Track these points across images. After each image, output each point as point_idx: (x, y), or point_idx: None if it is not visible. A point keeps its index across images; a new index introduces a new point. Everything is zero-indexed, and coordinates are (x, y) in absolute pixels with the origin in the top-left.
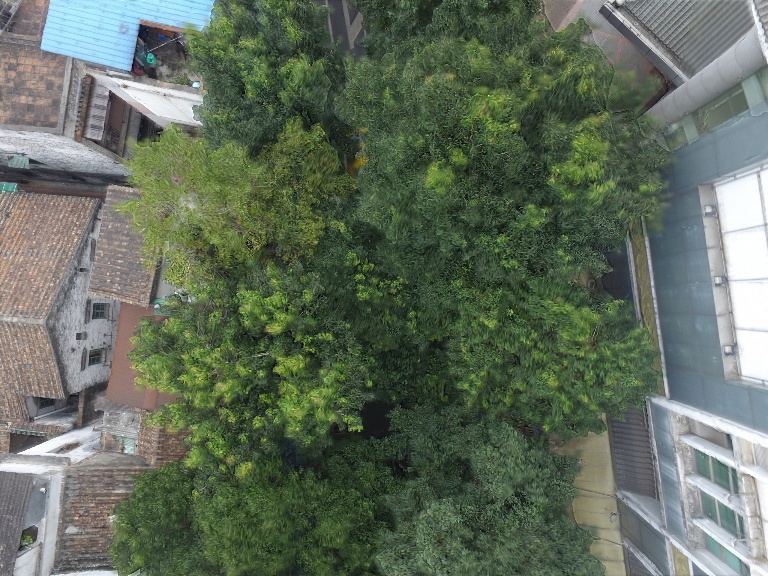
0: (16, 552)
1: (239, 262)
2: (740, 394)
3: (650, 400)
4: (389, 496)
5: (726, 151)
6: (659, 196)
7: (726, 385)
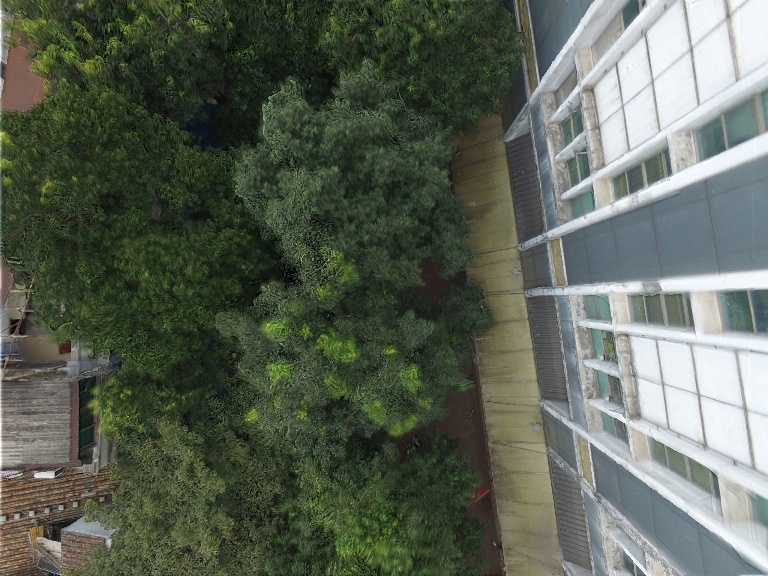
0: None
1: None
2: (575, 1)
3: (528, 105)
4: None
5: None
6: None
7: (567, 6)
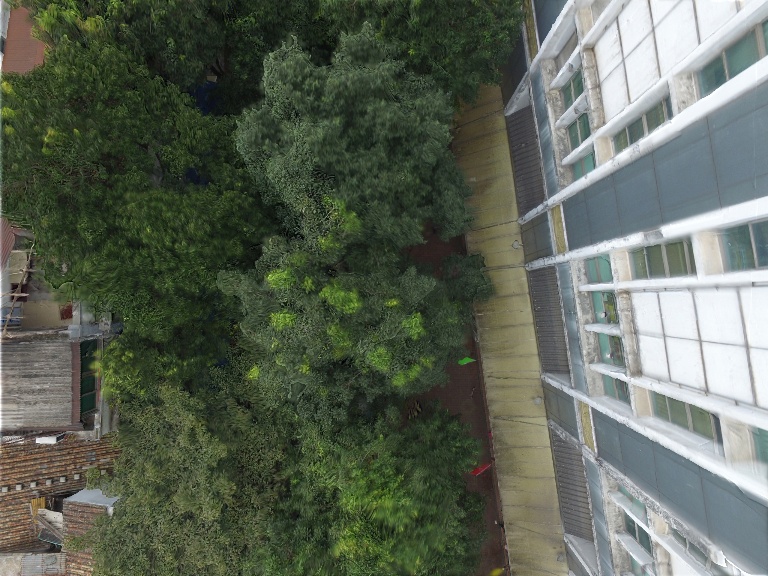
0: None
1: None
2: None
3: (529, 73)
4: None
5: None
6: None
7: None
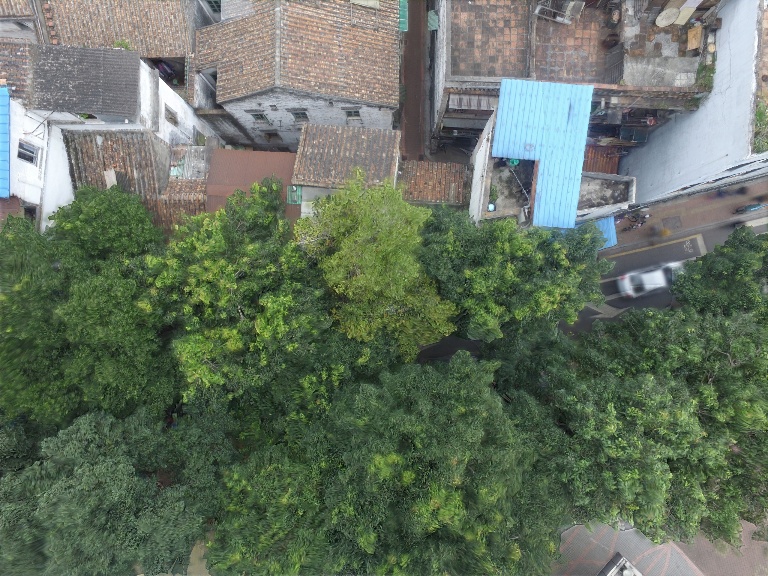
0: (73, 111)
1: None
2: None
3: None
4: (144, 411)
5: None
6: None
7: None
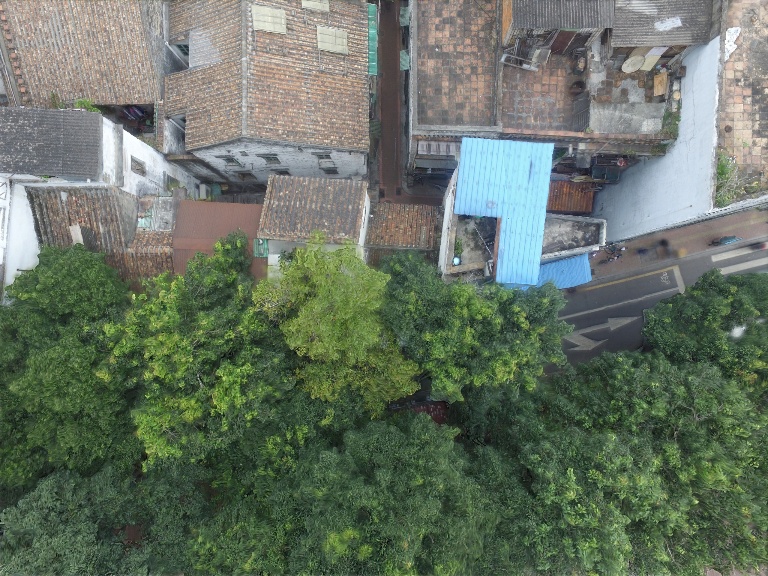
0: (33, 174)
1: None
2: None
3: None
4: (110, 470)
5: None
6: None
7: None
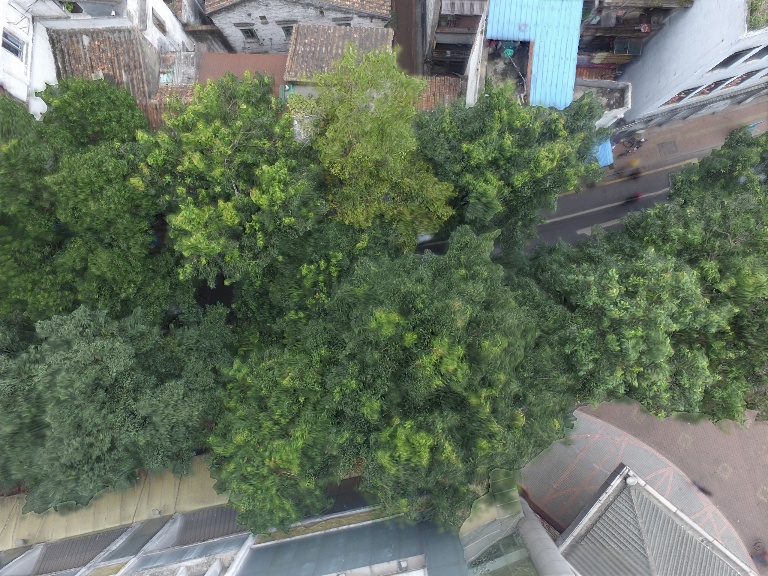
0: None
1: (320, 158)
2: None
3: None
4: (140, 310)
5: (447, 573)
6: (424, 524)
7: None
